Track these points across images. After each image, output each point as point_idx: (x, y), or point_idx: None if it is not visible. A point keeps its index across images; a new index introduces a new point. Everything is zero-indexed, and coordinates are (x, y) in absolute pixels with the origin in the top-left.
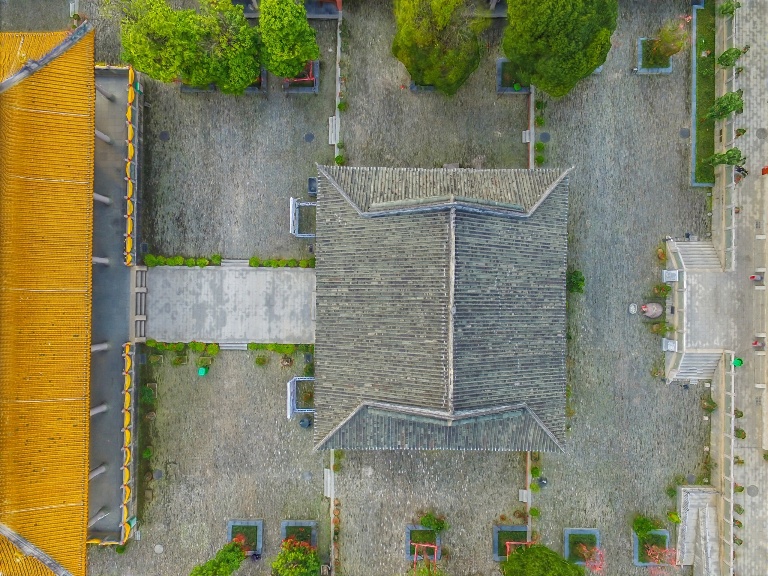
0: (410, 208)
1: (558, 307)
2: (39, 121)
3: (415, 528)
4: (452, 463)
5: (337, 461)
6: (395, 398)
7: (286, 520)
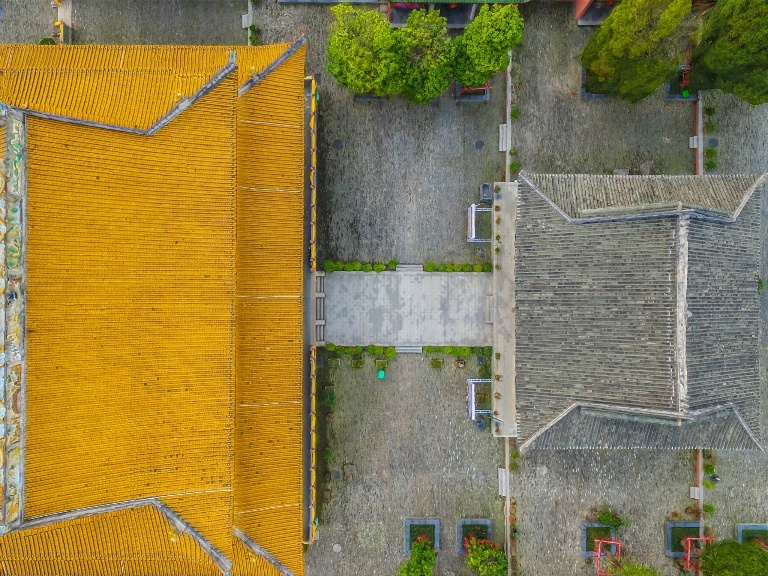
0: (634, 215)
1: (752, 309)
2: (257, 132)
3: (591, 525)
4: (624, 462)
5: (512, 461)
6: (613, 399)
7: (462, 519)
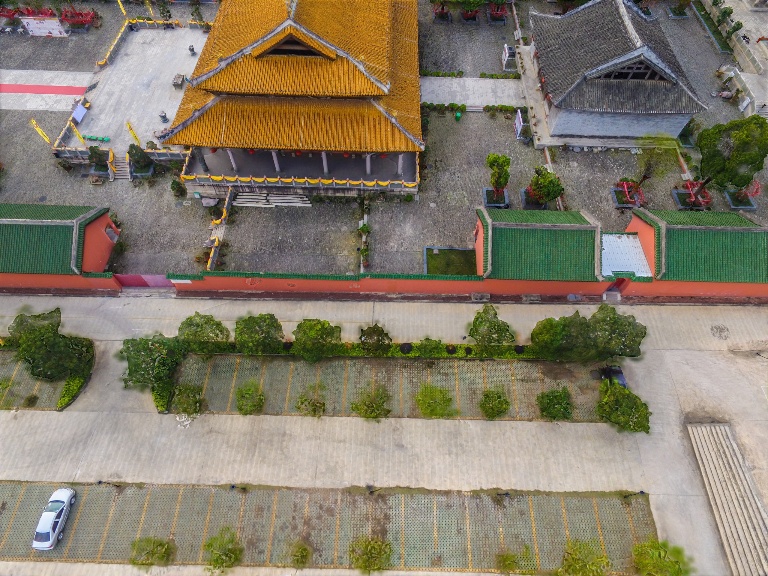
0: None
1: None
2: None
3: (617, 189)
4: None
5: None
6: None
7: None
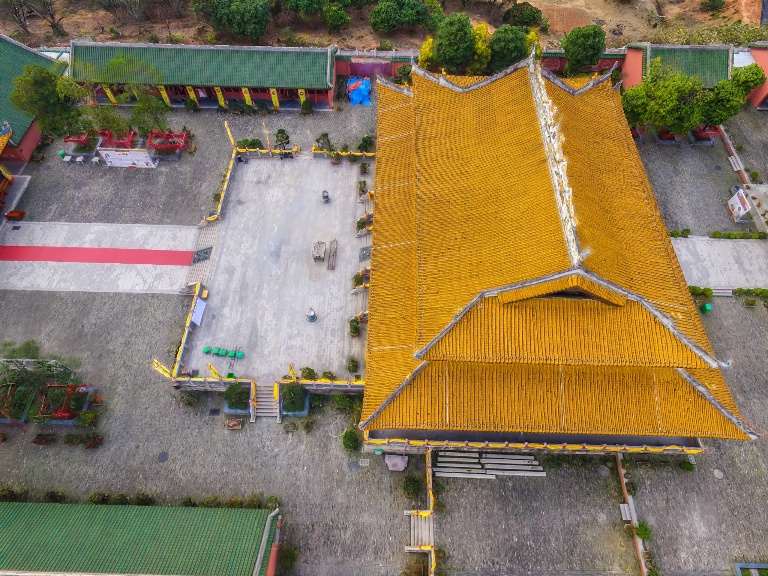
0: None
1: None
2: None
3: None
4: None
5: None
6: None
7: None
